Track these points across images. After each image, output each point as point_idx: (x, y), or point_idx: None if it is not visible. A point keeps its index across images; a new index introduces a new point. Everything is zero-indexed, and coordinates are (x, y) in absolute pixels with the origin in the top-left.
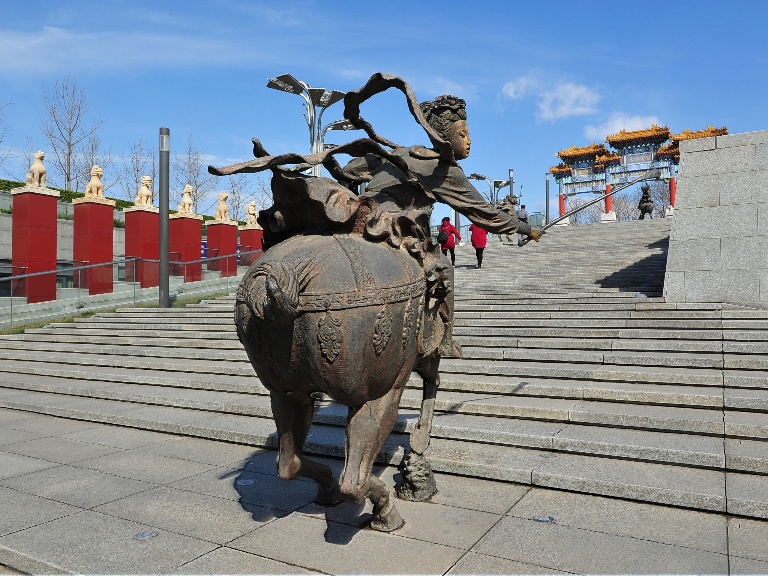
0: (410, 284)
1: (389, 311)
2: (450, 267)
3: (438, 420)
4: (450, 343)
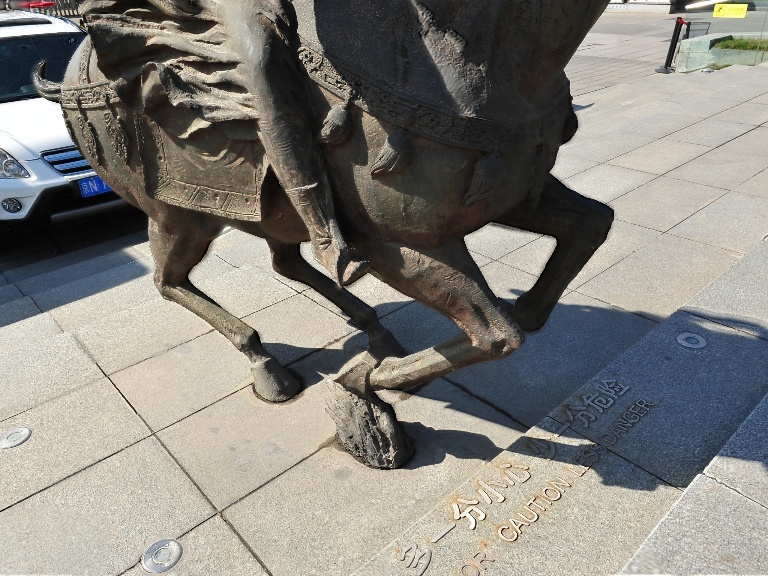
0: (79, 89)
1: (65, 117)
2: (245, 60)
3: (760, 526)
4: (311, 236)
